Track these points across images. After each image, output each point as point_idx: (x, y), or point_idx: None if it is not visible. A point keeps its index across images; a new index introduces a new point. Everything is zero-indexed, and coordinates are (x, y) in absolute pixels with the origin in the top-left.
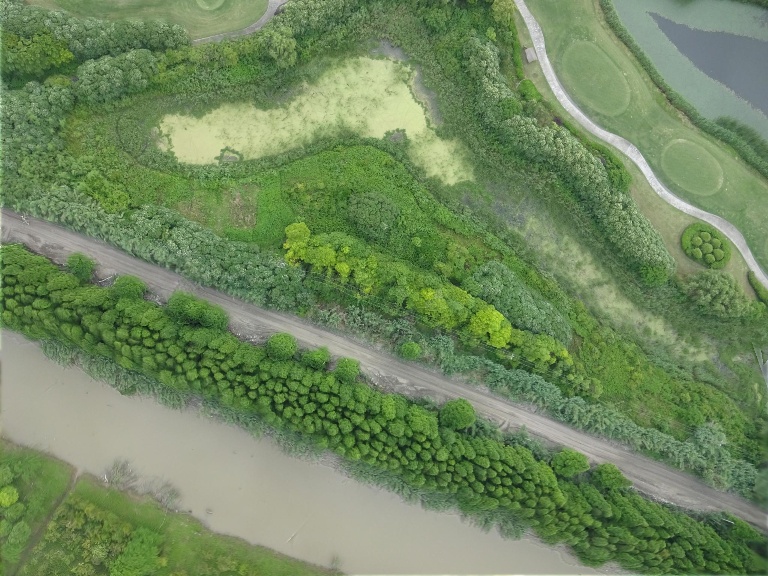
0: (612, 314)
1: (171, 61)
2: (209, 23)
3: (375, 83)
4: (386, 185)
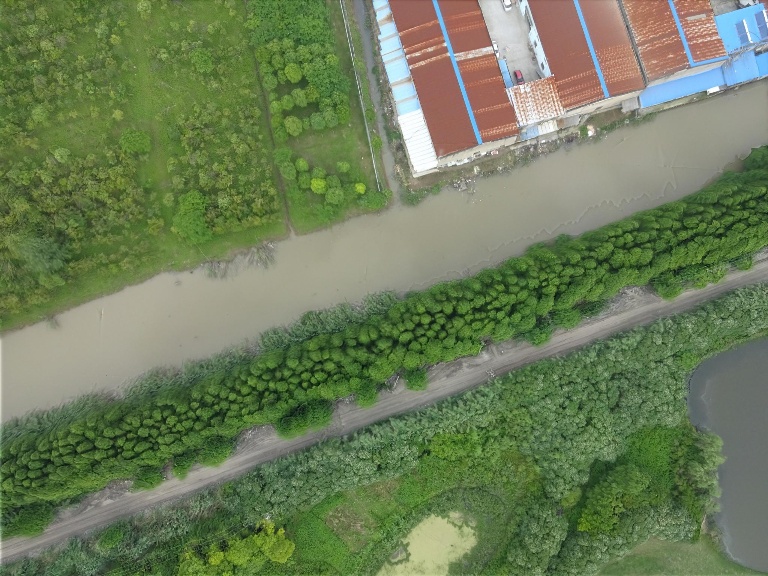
0: None
1: None
2: None
3: None
4: None
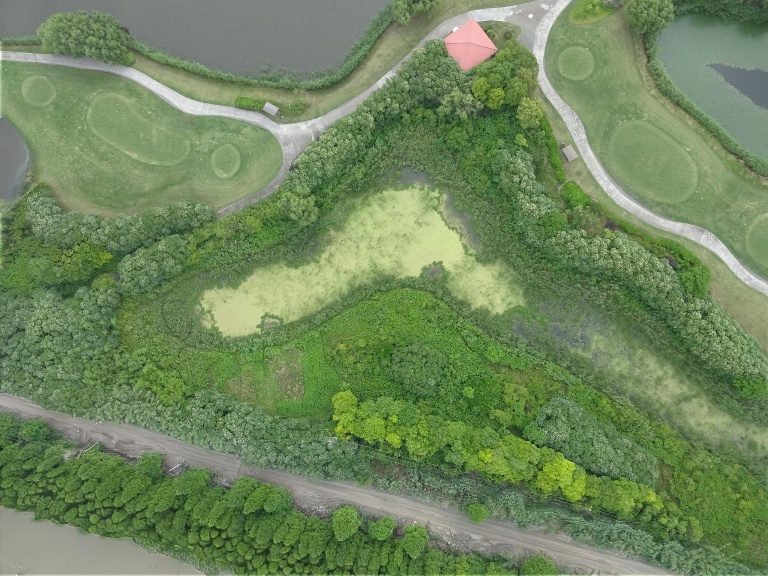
0: (706, 431)
1: (200, 240)
2: (229, 191)
3: (403, 217)
4: (429, 330)
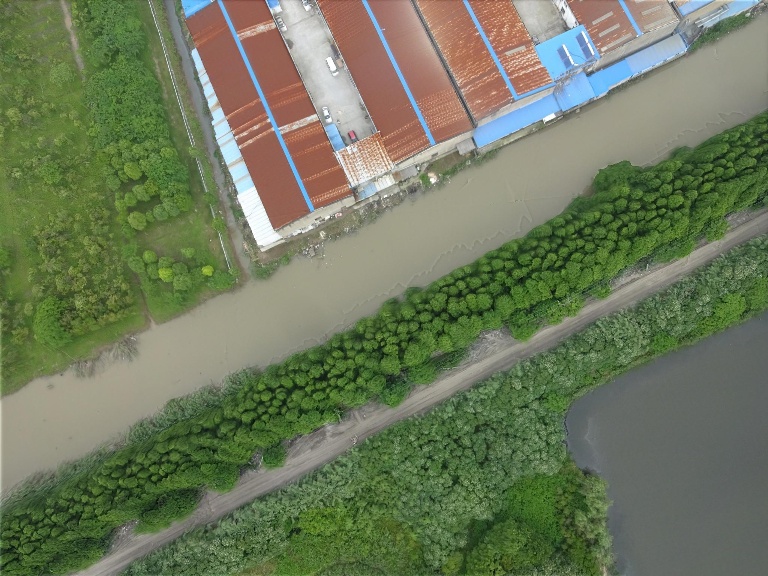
0: None
1: None
2: None
3: None
4: None
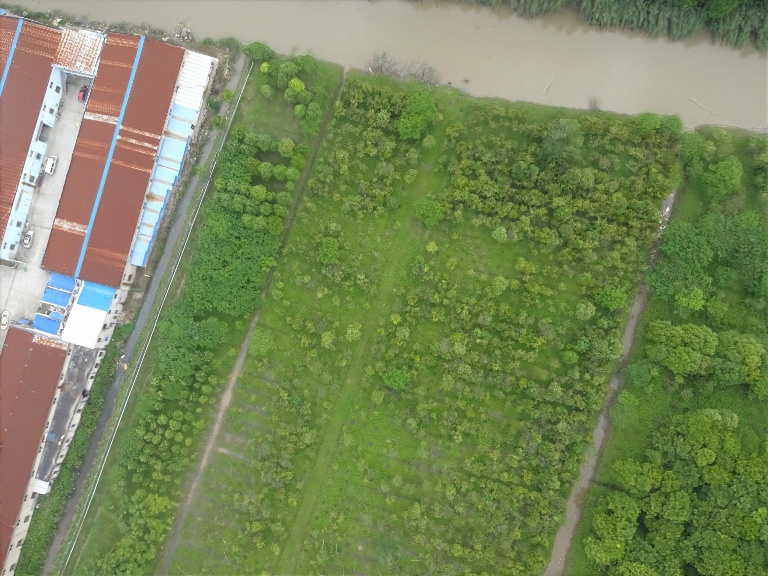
0: None
1: None
2: None
3: None
4: None
